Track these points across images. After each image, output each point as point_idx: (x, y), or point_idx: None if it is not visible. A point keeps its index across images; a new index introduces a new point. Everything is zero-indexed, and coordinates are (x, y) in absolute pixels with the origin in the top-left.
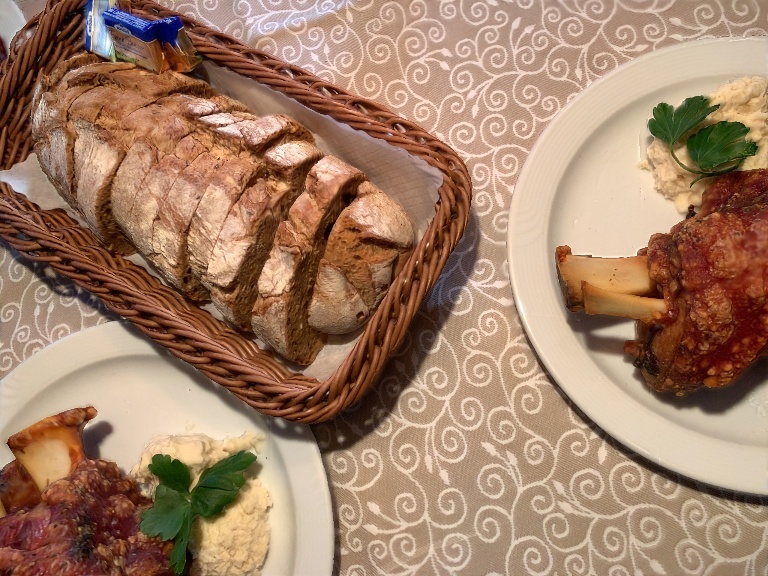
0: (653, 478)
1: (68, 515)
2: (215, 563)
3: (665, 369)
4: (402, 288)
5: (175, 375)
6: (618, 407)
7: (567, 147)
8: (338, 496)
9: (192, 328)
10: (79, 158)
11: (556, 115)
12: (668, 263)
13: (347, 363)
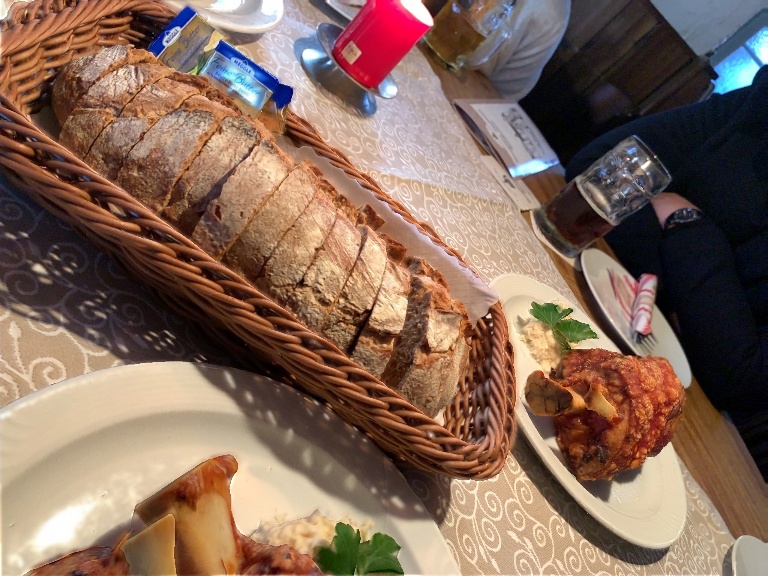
0: (597, 551)
1: None
2: None
3: (614, 456)
4: None
5: (253, 448)
6: (582, 491)
7: None
8: None
9: (365, 370)
10: (211, 153)
11: None
12: (606, 385)
13: (500, 422)
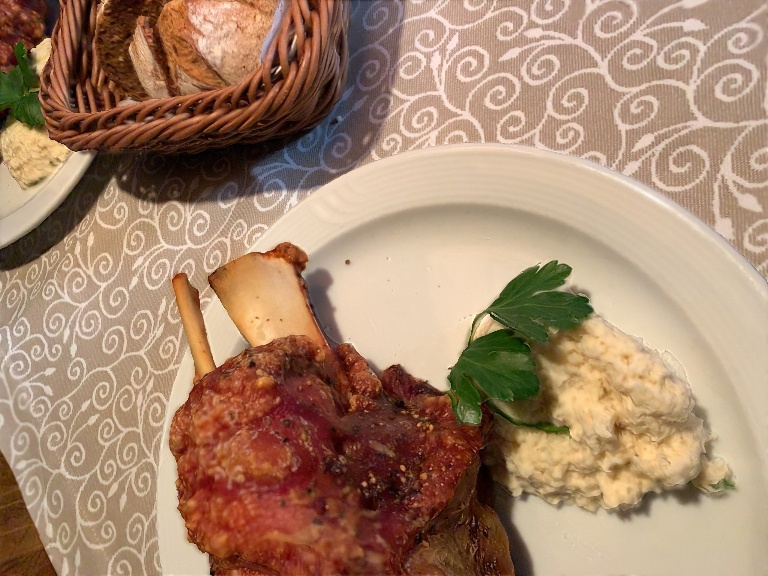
0: None
1: None
2: (2, 148)
3: None
4: (153, 110)
5: None
6: None
7: (463, 187)
8: (93, 207)
9: None
10: None
11: (500, 143)
12: None
13: None
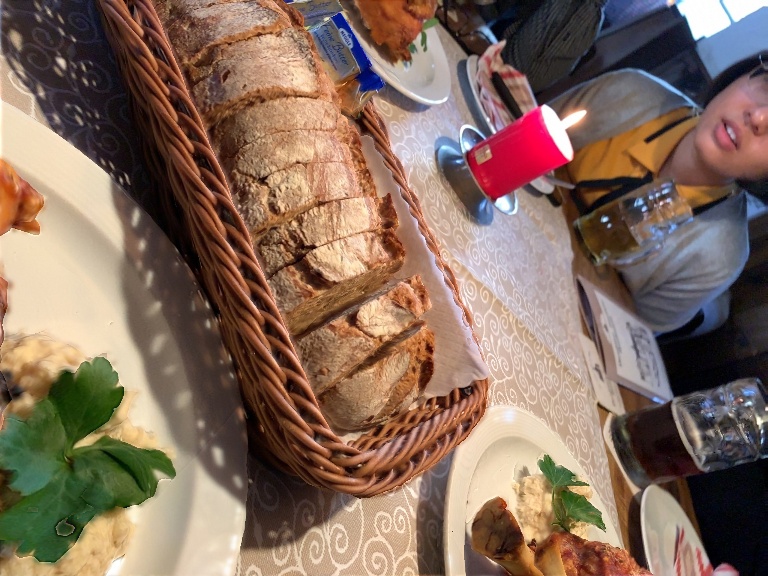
0: None
1: (2, 317)
2: None
3: None
4: None
5: (110, 291)
6: None
7: (495, 432)
8: None
9: None
10: (258, 44)
11: (497, 405)
12: (579, 566)
13: (392, 452)
